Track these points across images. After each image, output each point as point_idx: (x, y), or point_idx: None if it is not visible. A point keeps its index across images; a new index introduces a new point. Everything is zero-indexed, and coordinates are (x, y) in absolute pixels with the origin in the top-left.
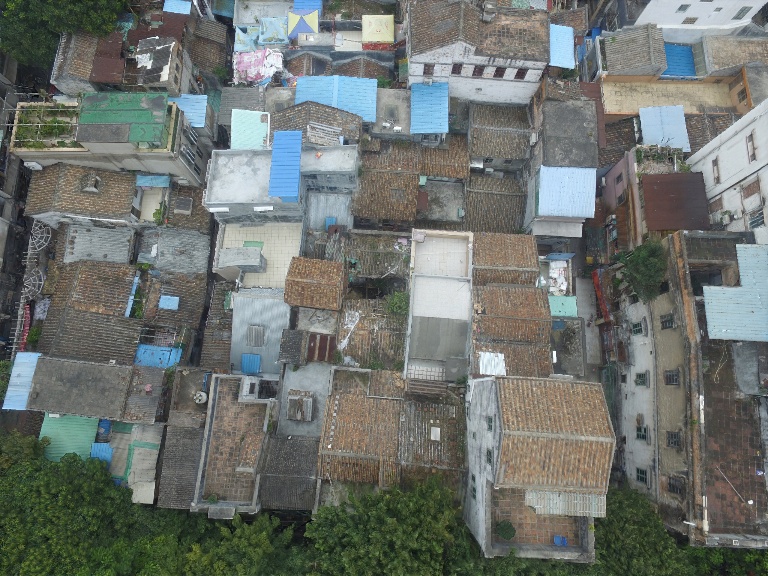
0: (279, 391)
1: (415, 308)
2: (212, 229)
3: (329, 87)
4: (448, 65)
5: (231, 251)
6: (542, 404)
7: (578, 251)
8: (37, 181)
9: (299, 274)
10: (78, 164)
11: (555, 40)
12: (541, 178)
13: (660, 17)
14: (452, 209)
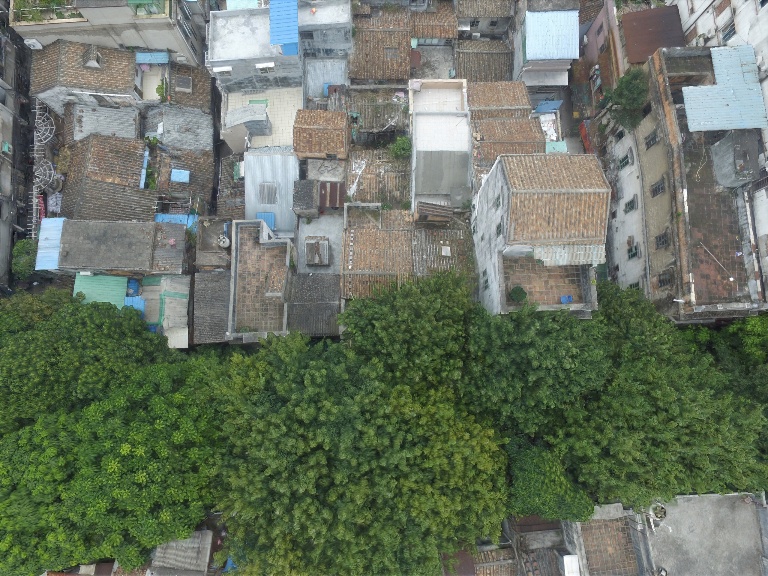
0: (296, 240)
1: (418, 143)
2: (213, 110)
3: None
4: None
5: (237, 110)
6: (544, 172)
7: (565, 113)
8: (38, 61)
9: (306, 122)
10: (77, 41)
11: None
12: (527, 24)
13: None
14: (444, 71)
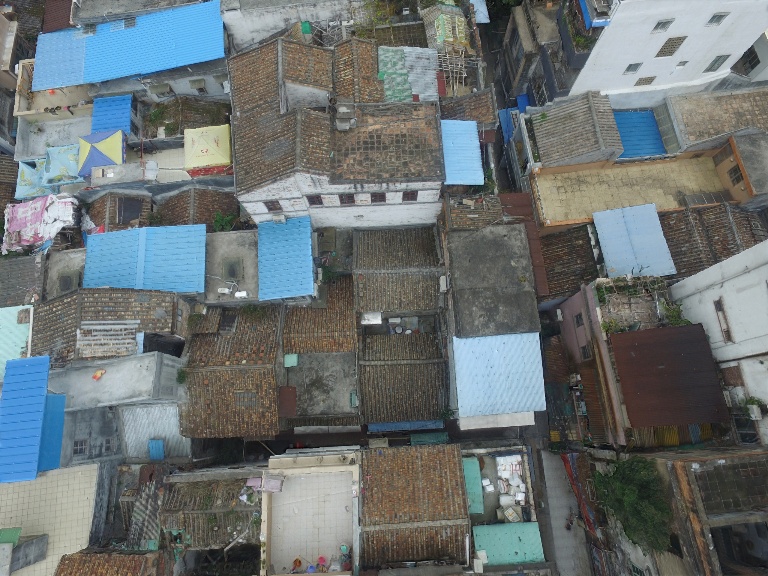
0: None
1: None
2: None
3: (132, 246)
4: (297, 199)
5: None
6: None
7: None
8: None
9: None
10: None
11: (451, 144)
12: (456, 357)
13: (602, 82)
14: (342, 394)
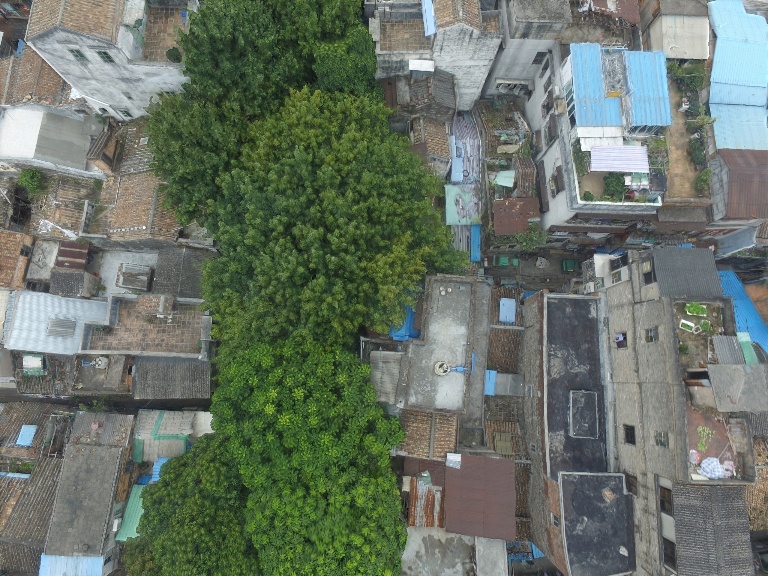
0: None
1: None
2: None
3: None
4: None
5: None
6: (48, 3)
7: None
8: None
9: None
10: None
11: None
12: None
13: None
14: None
